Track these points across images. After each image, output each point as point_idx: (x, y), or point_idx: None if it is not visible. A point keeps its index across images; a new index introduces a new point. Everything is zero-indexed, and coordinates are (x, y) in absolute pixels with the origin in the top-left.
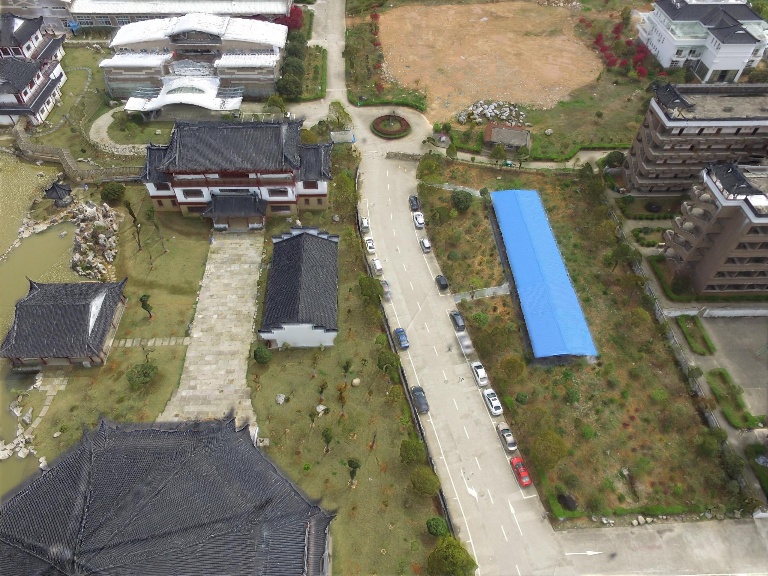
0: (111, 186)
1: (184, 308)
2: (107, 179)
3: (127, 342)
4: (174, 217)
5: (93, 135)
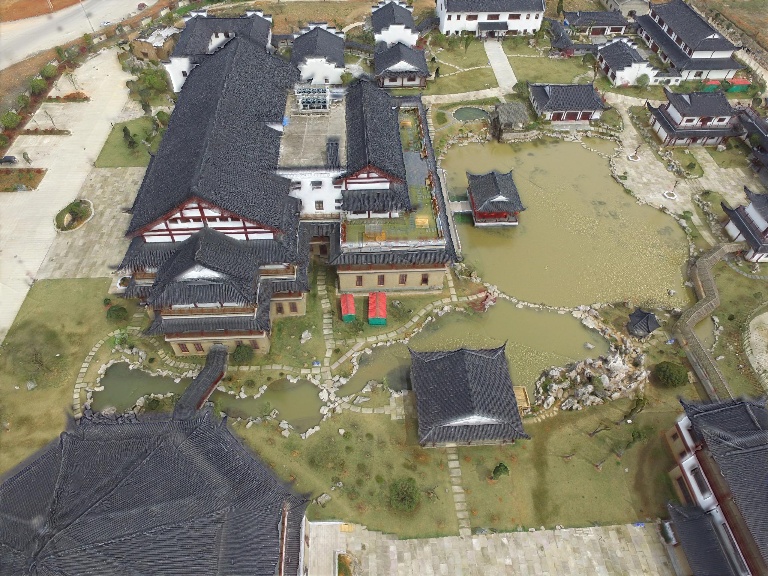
0: (676, 371)
1: (514, 515)
2: (696, 358)
3: (454, 462)
4: (664, 460)
5: (766, 317)
